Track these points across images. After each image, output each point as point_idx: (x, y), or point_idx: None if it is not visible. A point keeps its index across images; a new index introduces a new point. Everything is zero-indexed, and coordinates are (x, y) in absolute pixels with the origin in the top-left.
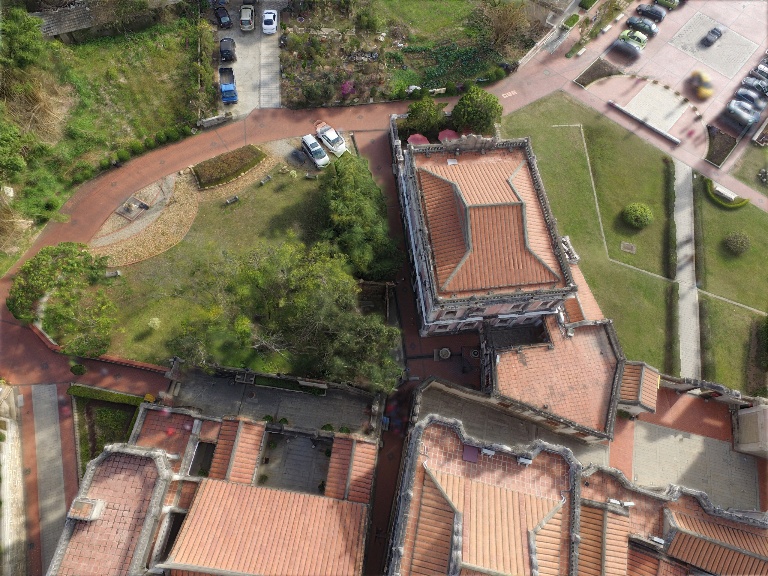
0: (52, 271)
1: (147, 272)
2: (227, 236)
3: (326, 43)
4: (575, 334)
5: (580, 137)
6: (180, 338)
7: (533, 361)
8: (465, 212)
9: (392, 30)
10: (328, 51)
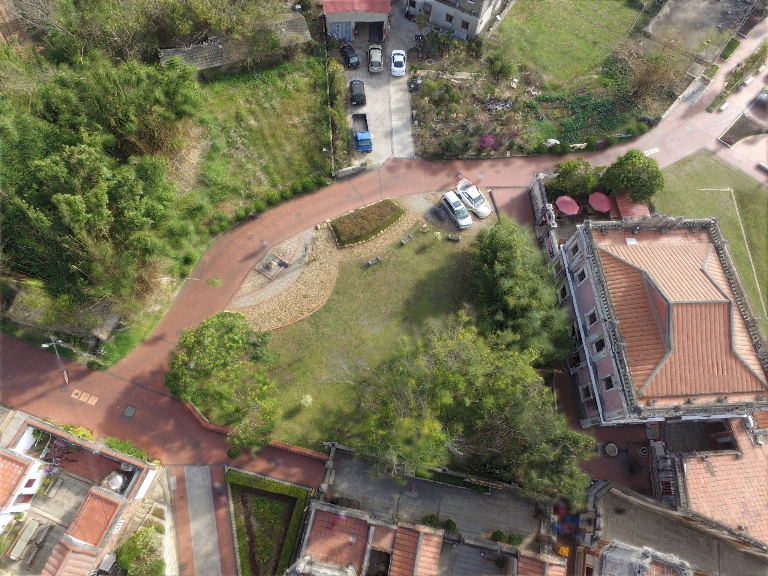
0: (218, 348)
1: (291, 339)
2: (371, 301)
3: (457, 88)
4: (765, 442)
5: (732, 203)
6: (372, 444)
7: (722, 471)
8: (667, 309)
9: (524, 76)
10: (461, 98)
